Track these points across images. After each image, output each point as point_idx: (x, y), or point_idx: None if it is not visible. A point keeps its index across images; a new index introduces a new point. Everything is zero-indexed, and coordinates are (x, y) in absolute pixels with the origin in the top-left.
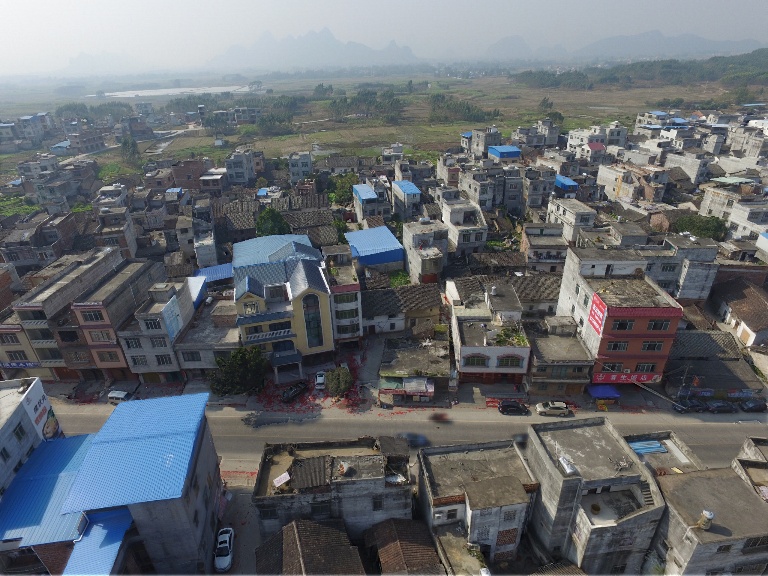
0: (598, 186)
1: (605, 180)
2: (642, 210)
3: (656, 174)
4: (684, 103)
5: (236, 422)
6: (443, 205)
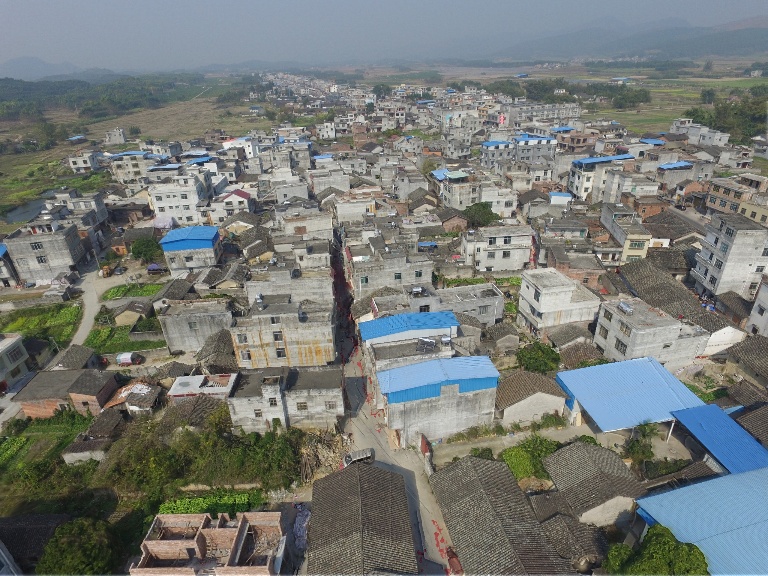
0: None
1: (351, 216)
2: (434, 223)
3: None
4: (9, 147)
5: None
6: (546, 292)
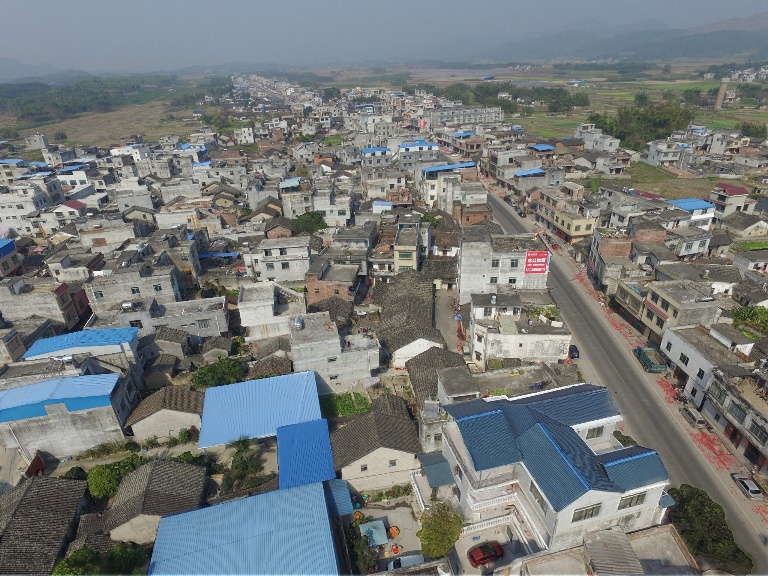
0: (202, 230)
1: None
2: (256, 232)
3: (212, 203)
4: None
5: (724, 573)
6: (241, 307)
